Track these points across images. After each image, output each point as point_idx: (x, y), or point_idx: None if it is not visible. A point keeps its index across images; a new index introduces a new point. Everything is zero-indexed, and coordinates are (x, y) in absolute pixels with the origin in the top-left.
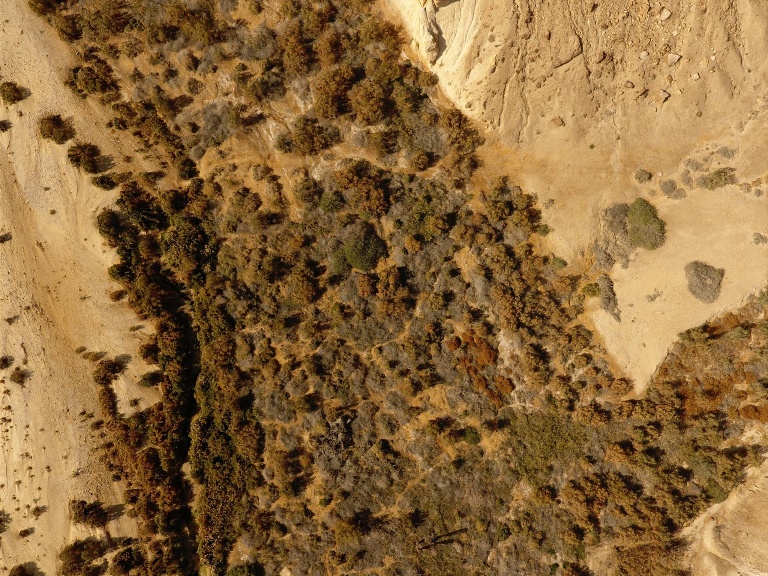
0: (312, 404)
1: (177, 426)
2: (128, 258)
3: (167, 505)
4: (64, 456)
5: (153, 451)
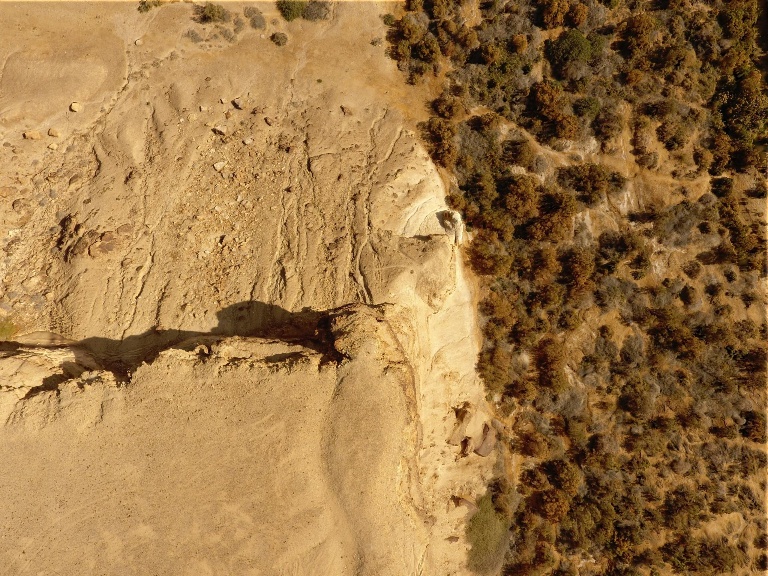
0: None
1: None
2: None
3: None
4: None
5: None
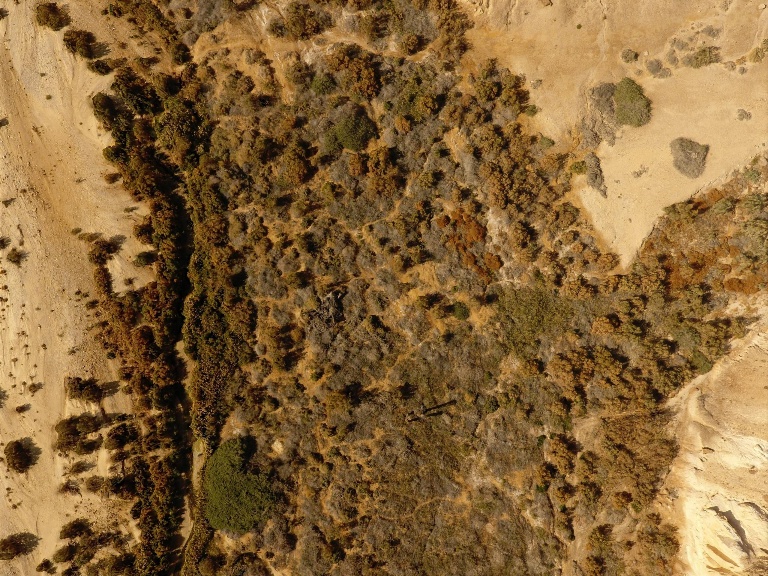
0: (303, 280)
1: (171, 304)
2: (123, 140)
3: (161, 378)
4: (60, 334)
5: (147, 328)
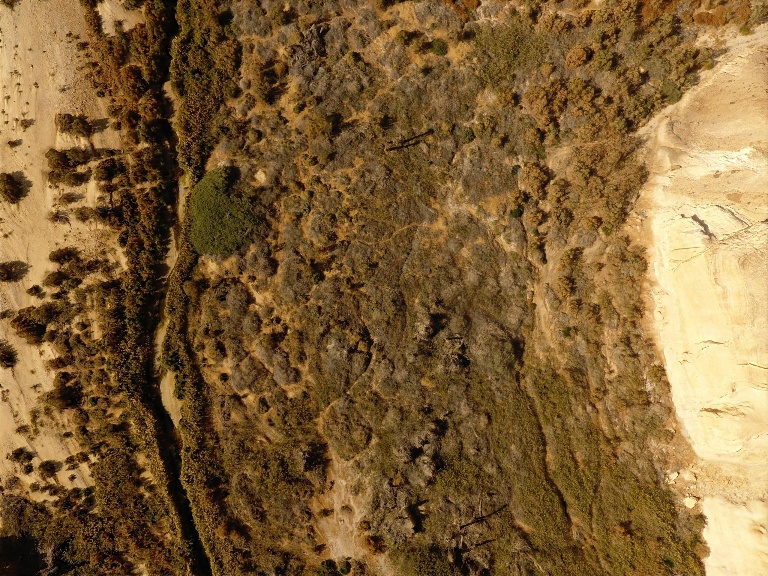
0: (287, 17)
1: (159, 43)
2: None
3: (148, 108)
4: (51, 74)
5: (136, 67)
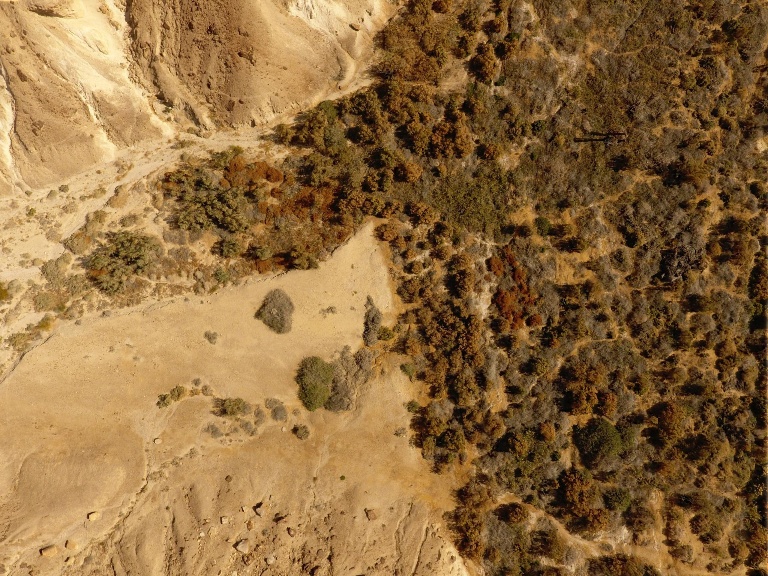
0: (694, 302)
1: None
2: None
3: None
4: None
5: None
